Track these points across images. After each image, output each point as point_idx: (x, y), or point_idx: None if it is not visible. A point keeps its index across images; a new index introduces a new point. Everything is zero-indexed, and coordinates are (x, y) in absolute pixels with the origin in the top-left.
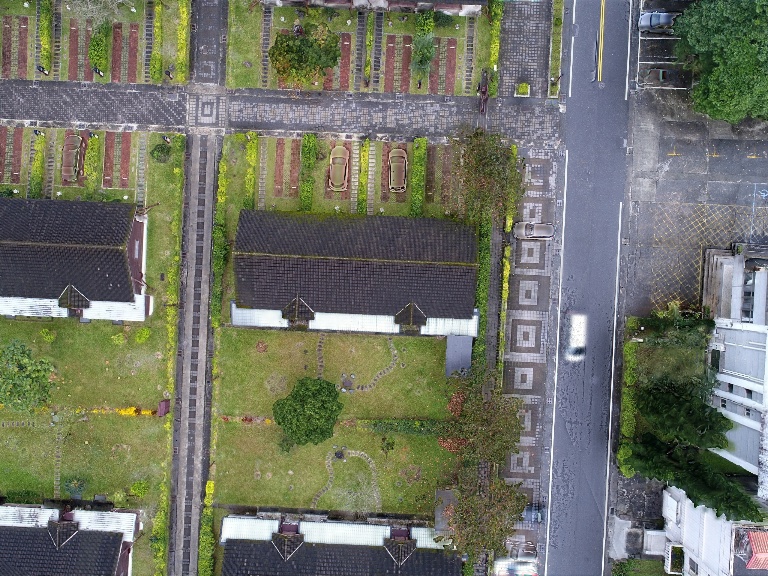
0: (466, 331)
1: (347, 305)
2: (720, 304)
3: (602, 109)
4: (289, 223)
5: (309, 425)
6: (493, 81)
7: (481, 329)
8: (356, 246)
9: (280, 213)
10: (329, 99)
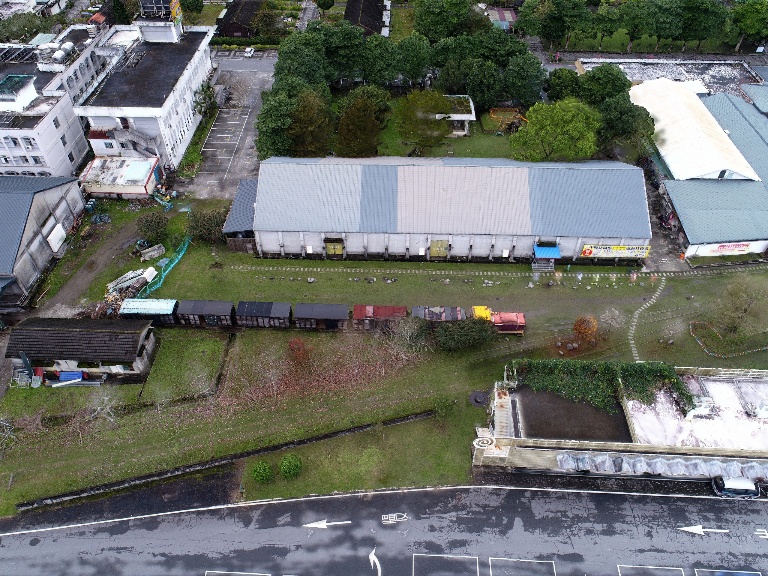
0: None
1: None
2: None
3: None
4: (262, 0)
5: None
6: None
7: None
8: (249, 5)
9: (267, 1)
10: None
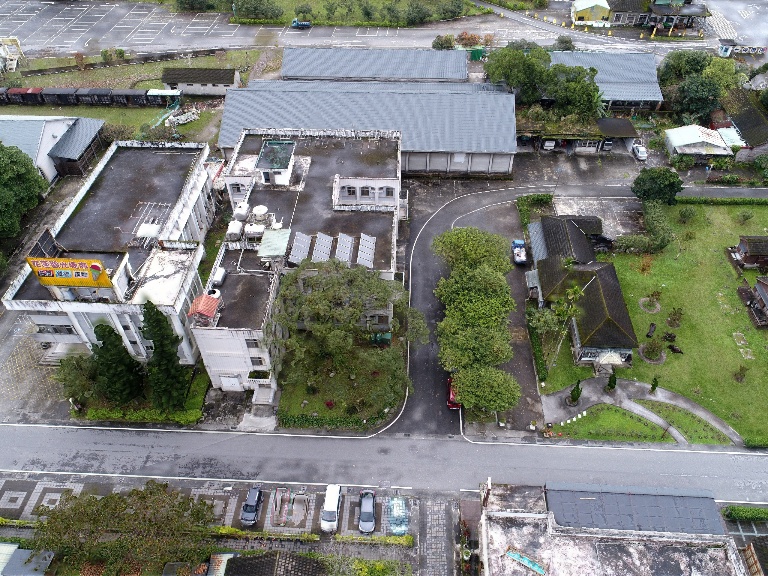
0: (7, 556)
1: None
2: (84, 354)
3: None
4: None
5: None
6: None
7: (18, 542)
8: None
9: None
10: None
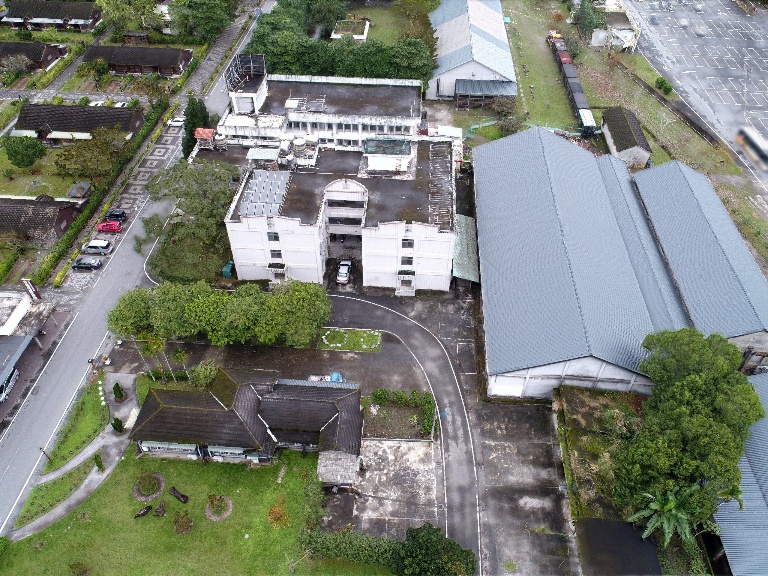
0: None
1: (69, 127)
2: None
3: (223, 97)
4: None
5: (21, 145)
6: (177, 90)
7: (134, 143)
8: None
9: None
10: (103, 94)
